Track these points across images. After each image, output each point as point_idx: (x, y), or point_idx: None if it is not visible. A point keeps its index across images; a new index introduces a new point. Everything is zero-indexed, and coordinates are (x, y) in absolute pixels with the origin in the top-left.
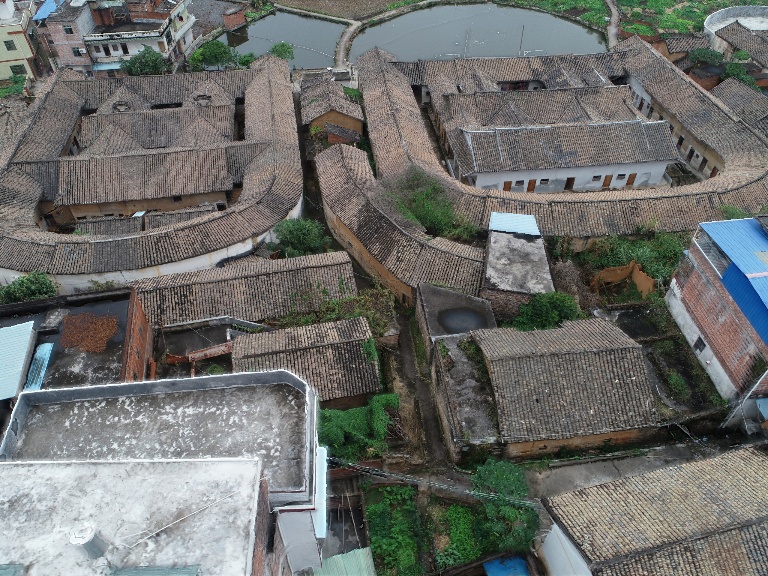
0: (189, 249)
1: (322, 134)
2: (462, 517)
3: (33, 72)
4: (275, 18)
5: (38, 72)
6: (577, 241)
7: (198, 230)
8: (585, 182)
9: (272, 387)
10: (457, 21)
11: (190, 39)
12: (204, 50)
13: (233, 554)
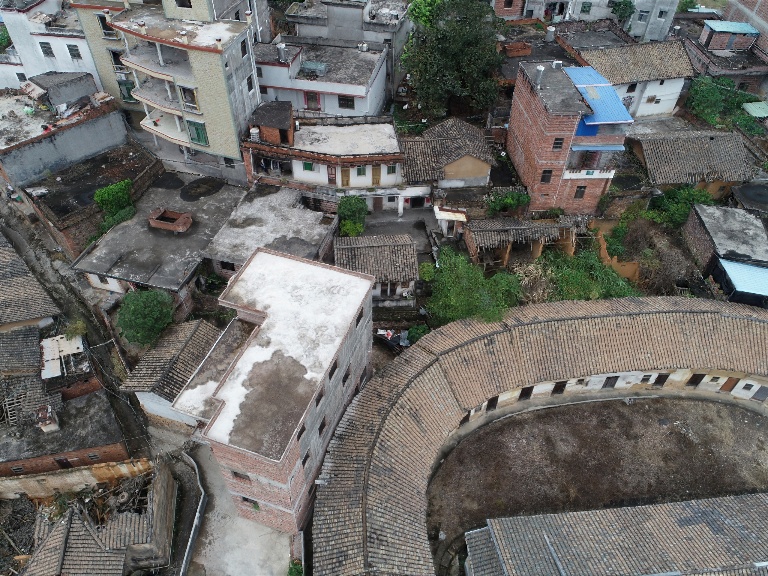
0: None
1: None
2: None
3: None
4: None
5: None
6: None
7: None
8: None
9: None
10: None
11: None
12: None
13: None
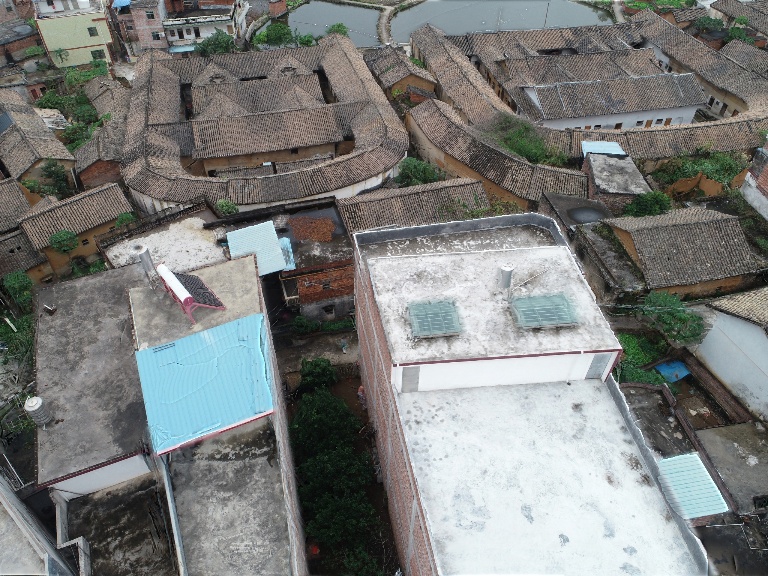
0: (338, 181)
1: (404, 95)
2: (630, 340)
3: (111, 56)
4: (309, 6)
5: (114, 57)
6: (649, 163)
7: (342, 166)
8: (630, 127)
9: (522, 227)
10: (478, 4)
11: (244, 25)
12: (269, 32)
13: (579, 290)
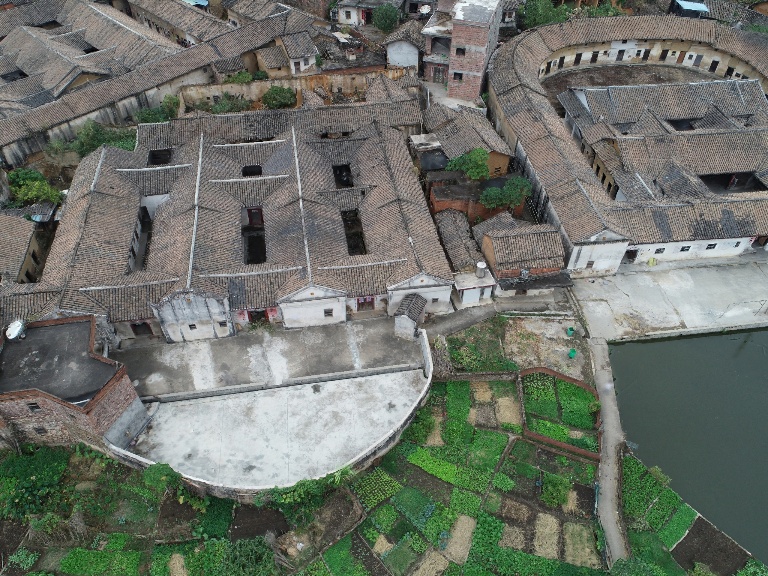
0: None
1: None
2: None
3: None
4: None
5: None
6: None
7: None
8: None
9: None
10: None
11: None
12: None
13: None
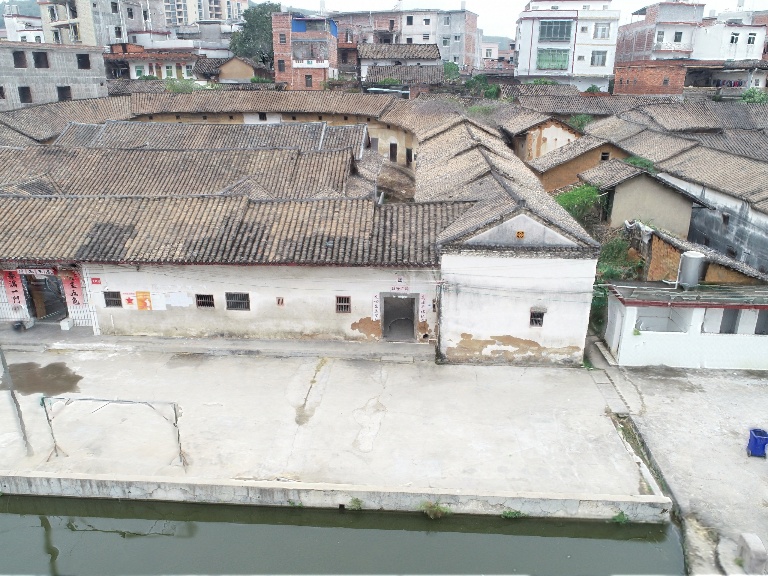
0: None
1: None
2: None
3: None
4: None
5: None
6: None
7: None
8: None
9: None
10: None
11: None
12: None
13: None
